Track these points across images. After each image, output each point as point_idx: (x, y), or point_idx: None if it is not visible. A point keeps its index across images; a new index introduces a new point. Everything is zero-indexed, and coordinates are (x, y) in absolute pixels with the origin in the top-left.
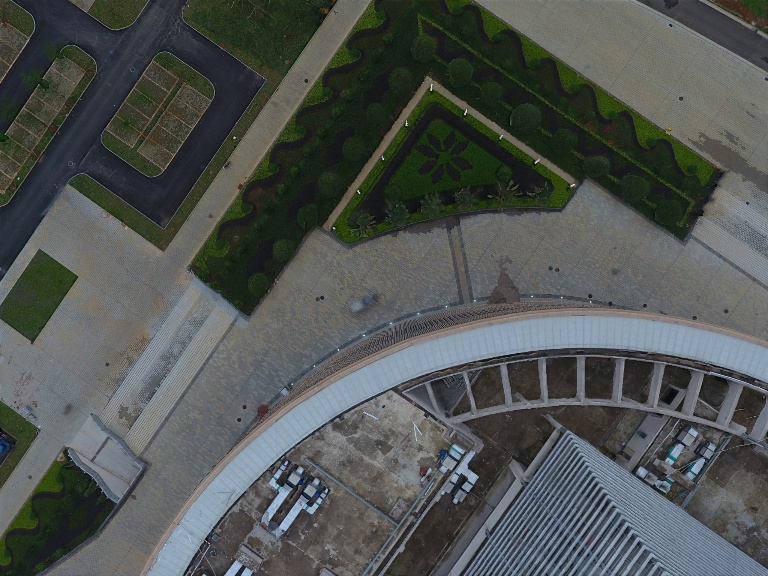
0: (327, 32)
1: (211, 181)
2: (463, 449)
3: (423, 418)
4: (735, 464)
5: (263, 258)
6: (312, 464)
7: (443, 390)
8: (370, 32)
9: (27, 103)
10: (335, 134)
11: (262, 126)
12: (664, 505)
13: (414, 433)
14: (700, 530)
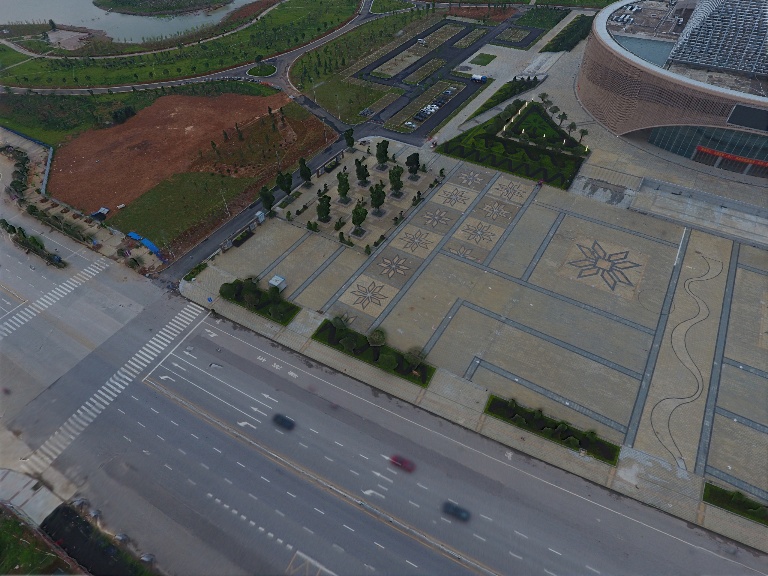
0: (562, 23)
1: (538, 41)
2: (676, 0)
3: None
4: None
5: (567, 44)
6: (633, 6)
7: None
8: (576, 21)
9: (467, 35)
10: (577, 30)
11: (550, 34)
12: None
13: (659, 3)
14: None
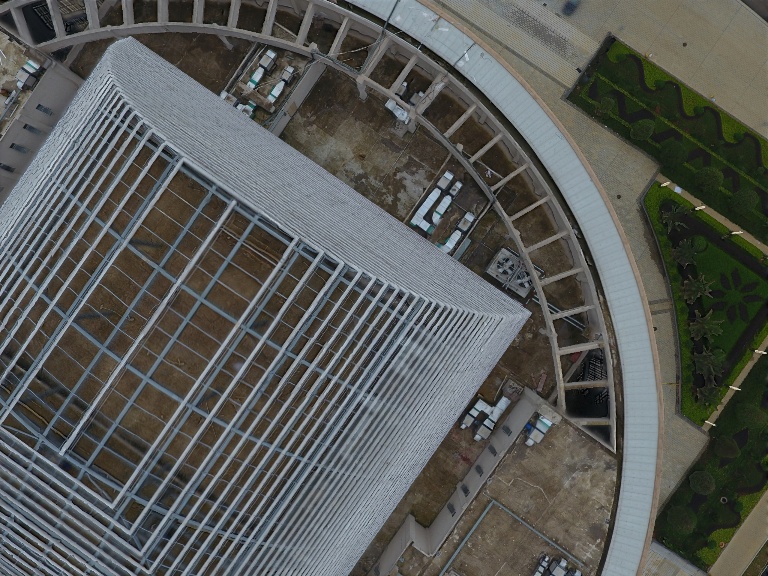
0: None
1: None
2: (35, 62)
3: (7, 42)
4: (343, 113)
5: None
6: None
7: (45, 31)
8: None
9: None
10: None
11: None
12: (209, 95)
13: None
14: (244, 119)
